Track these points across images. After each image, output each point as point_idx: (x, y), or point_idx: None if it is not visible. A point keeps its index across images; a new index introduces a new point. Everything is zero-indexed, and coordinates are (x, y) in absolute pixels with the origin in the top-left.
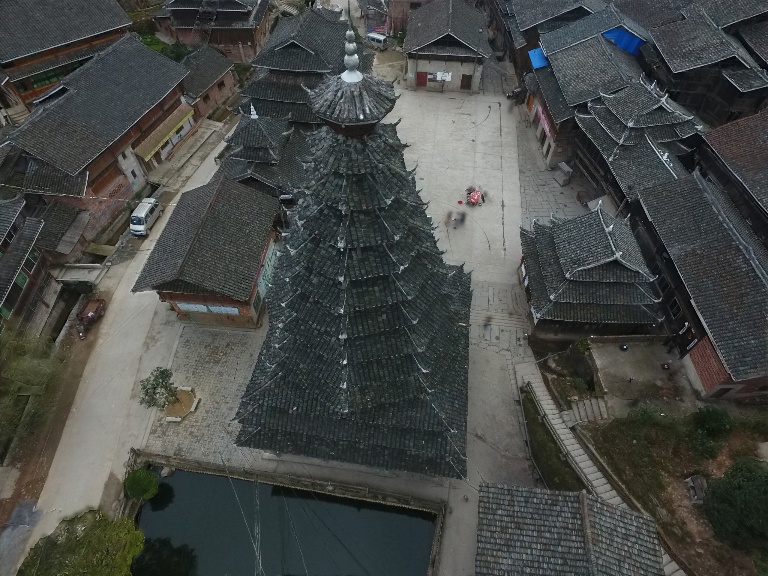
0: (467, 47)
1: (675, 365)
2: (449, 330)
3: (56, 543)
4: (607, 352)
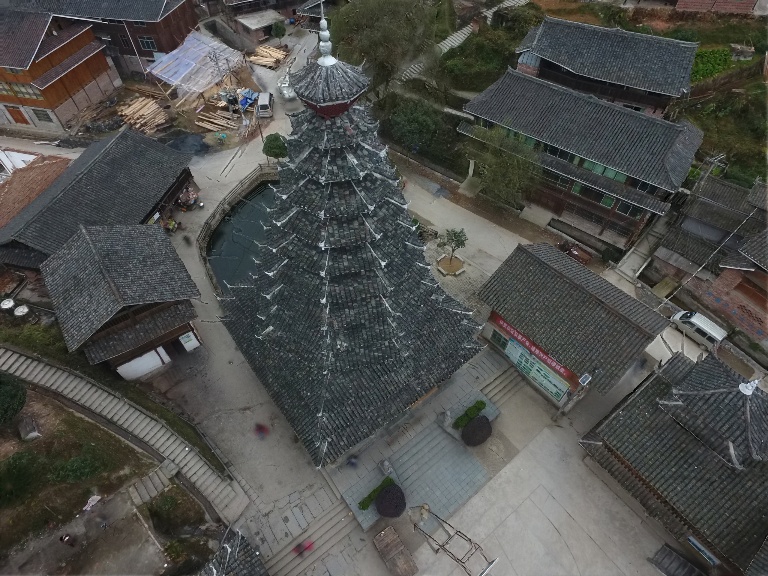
0: None
1: None
2: (263, 299)
3: None
4: (144, 575)
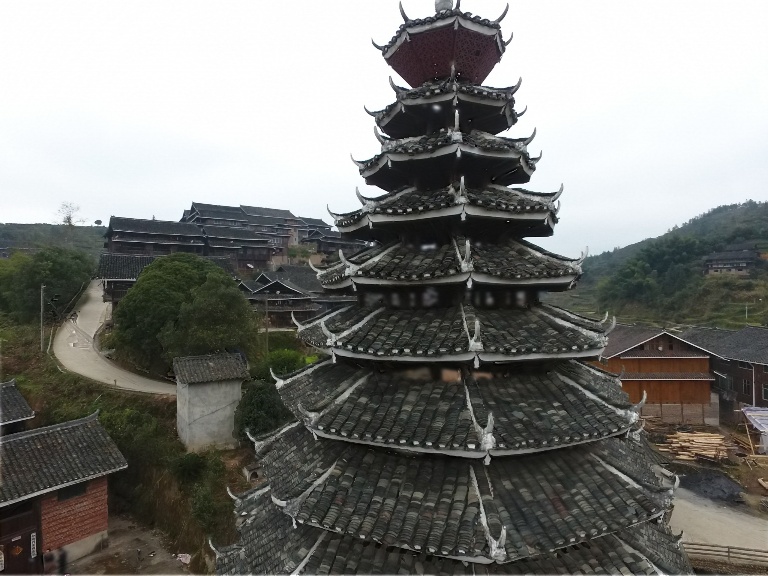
0: None
1: None
2: None
3: None
4: None
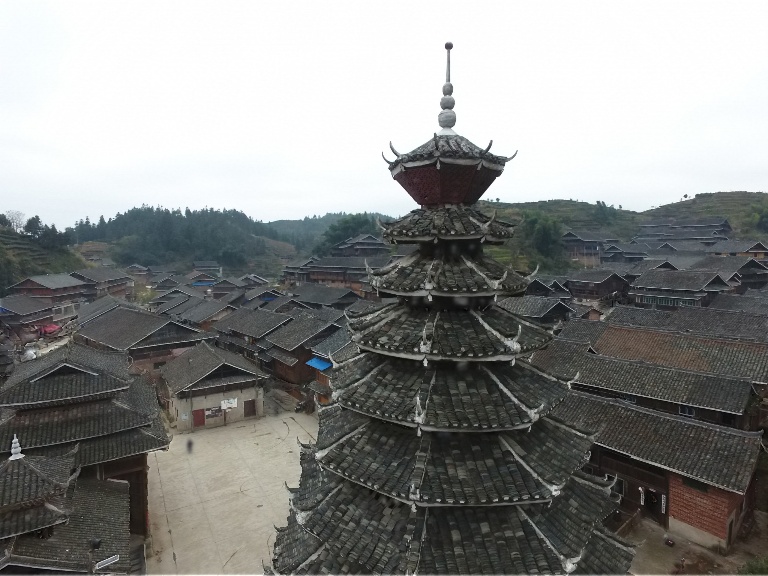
0: (243, 374)
1: (671, 538)
2: None
3: None
4: None
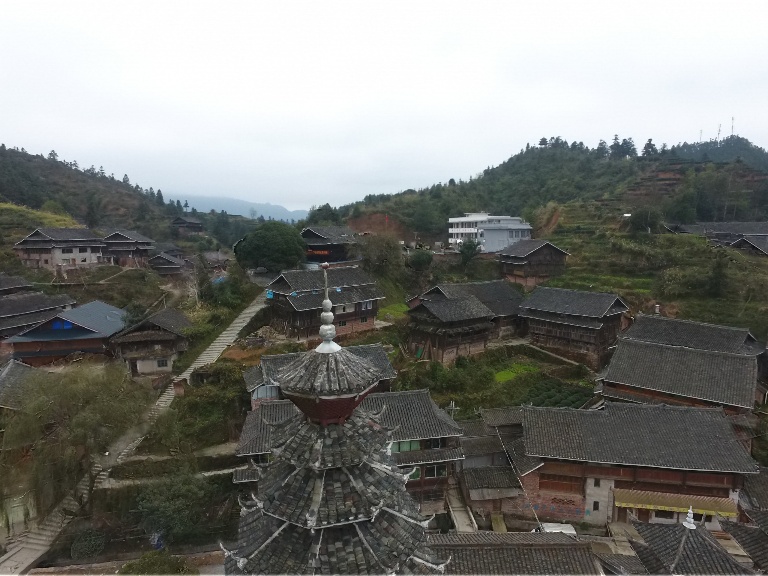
0: None
1: None
2: None
3: (178, 569)
4: None
